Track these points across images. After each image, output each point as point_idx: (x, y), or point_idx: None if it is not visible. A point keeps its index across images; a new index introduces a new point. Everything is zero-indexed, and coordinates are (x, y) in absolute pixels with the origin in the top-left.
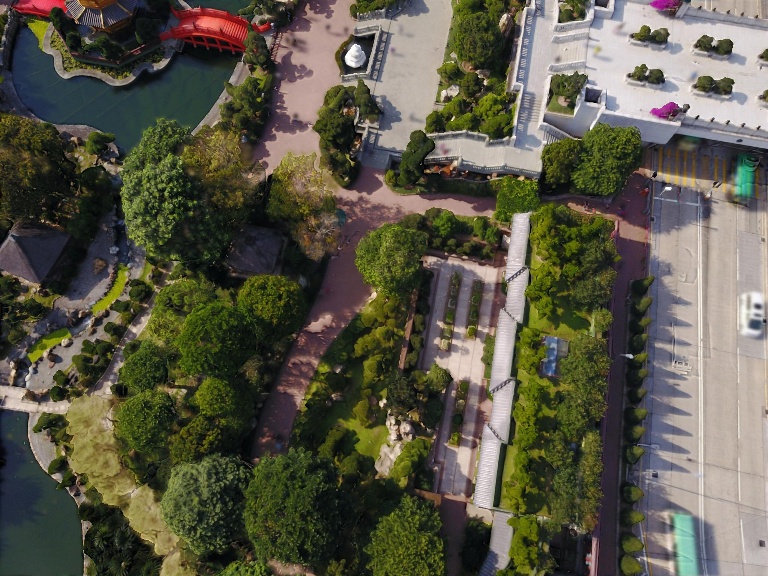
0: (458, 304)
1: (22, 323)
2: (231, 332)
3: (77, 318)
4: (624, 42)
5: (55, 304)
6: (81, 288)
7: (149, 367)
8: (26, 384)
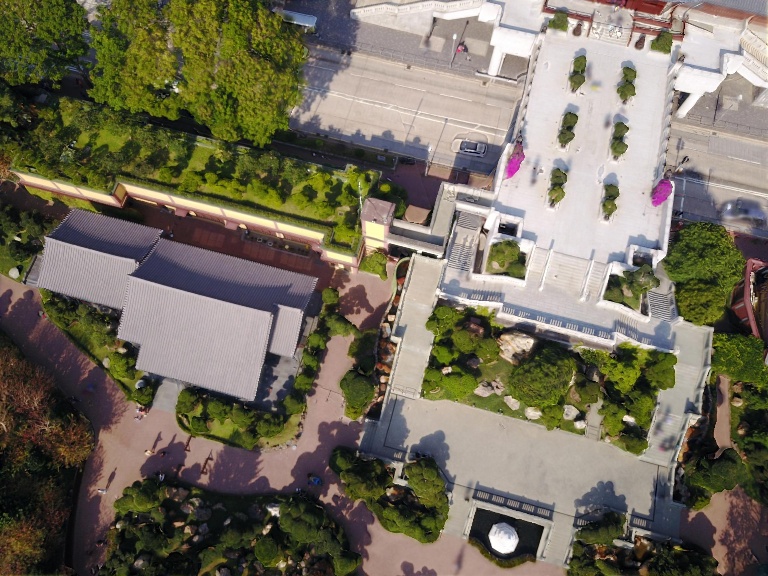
0: None
1: None
2: None
3: None
4: (554, 214)
5: None
6: None
7: None
8: None
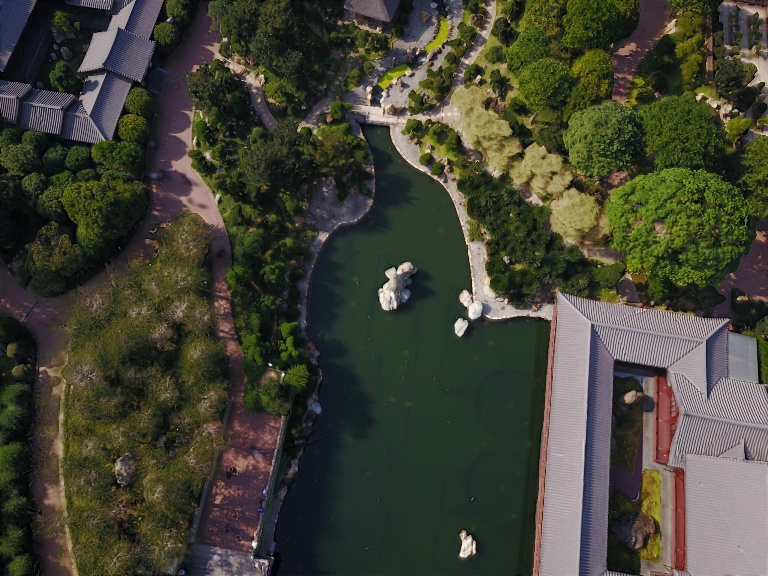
0: (739, 32)
1: (369, 60)
2: (612, 7)
3: (414, 56)
4: None
5: (393, 46)
6: (413, 33)
7: (541, 42)
8: (381, 106)
